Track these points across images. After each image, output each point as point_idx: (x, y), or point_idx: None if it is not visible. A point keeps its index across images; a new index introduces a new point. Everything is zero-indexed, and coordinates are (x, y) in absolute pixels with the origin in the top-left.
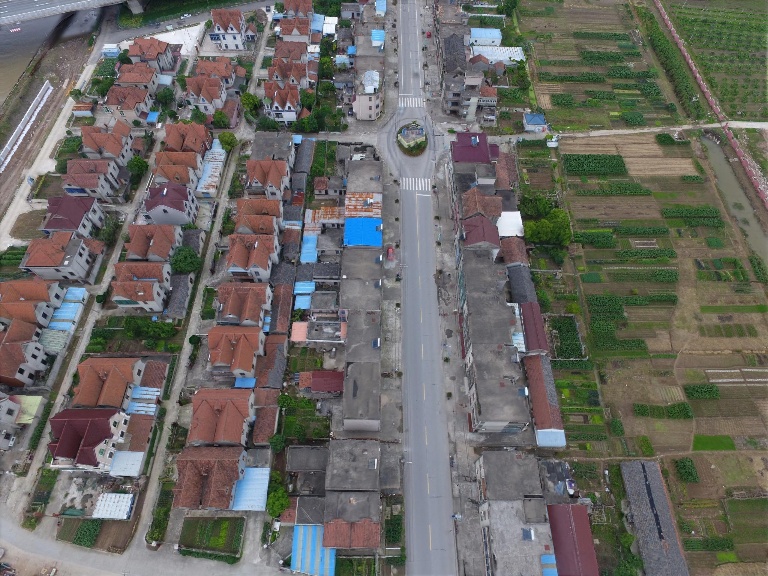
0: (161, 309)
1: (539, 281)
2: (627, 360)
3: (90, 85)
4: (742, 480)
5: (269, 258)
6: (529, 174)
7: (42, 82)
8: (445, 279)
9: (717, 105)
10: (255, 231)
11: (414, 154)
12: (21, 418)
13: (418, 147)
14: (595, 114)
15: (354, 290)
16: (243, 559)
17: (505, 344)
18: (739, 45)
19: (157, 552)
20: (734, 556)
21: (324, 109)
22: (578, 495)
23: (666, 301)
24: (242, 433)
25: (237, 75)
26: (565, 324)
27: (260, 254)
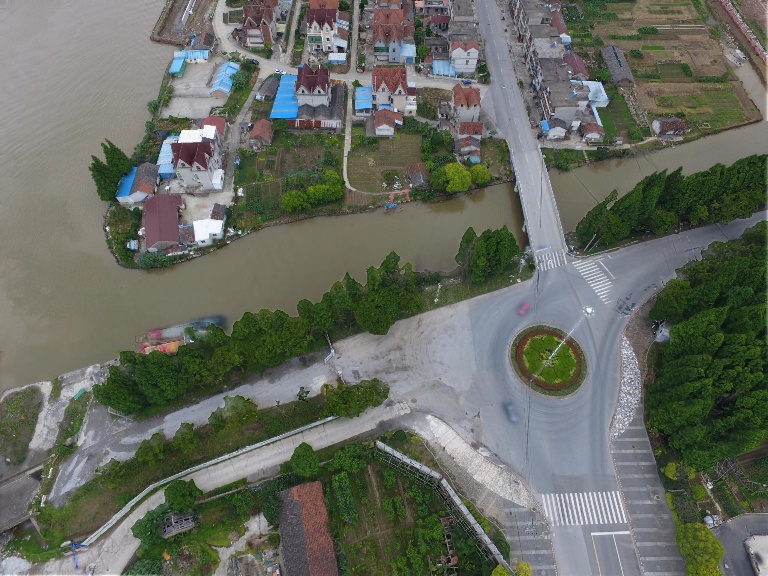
0: None
1: None
2: (606, 21)
3: None
4: (667, 59)
5: None
6: None
7: None
8: None
9: None
10: None
11: None
12: (278, 30)
13: None
14: None
15: None
16: (407, 75)
17: None
18: None
19: (363, 74)
20: None
21: None
22: None
23: (630, 1)
24: None
25: None
26: (570, 7)
27: None
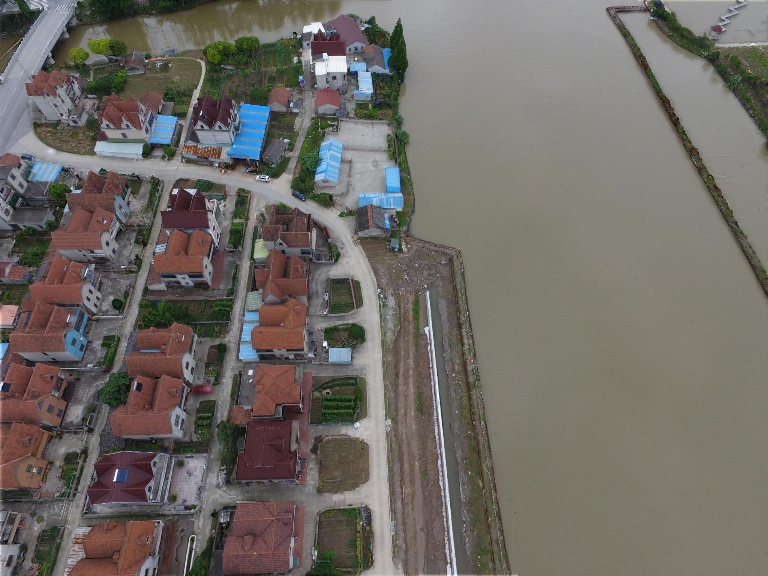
0: None
1: None
2: None
3: None
4: None
5: None
6: None
7: None
8: None
9: None
10: None
11: None
12: None
13: None
14: None
15: None
16: None
17: None
18: None
19: None
20: None
21: None
22: None
23: None
24: None
25: None
26: None
27: None
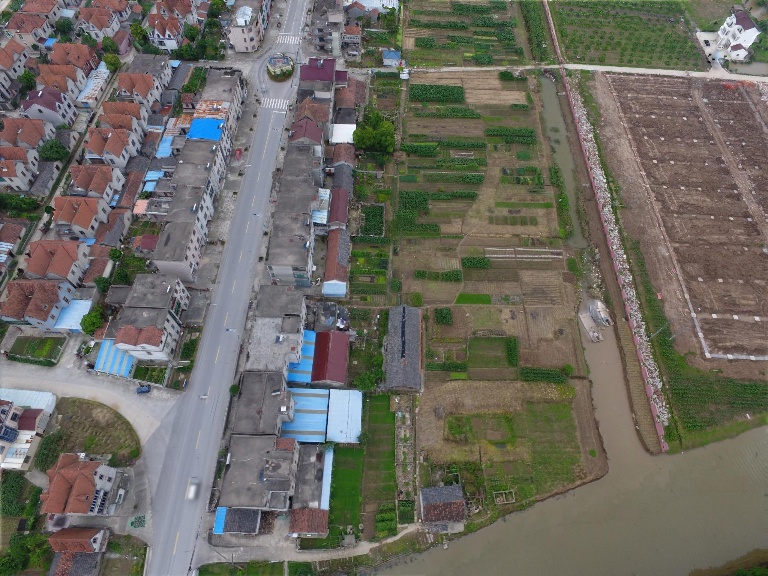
0: (27, 188)
1: (360, 178)
2: (420, 239)
3: (1, 16)
4: (489, 325)
5: (125, 150)
6: (378, 99)
7: None
8: None
9: (562, 51)
10: (116, 128)
11: (279, 80)
12: None
13: (284, 74)
14: (451, 54)
15: (186, 171)
16: (59, 364)
17: (303, 213)
18: (598, 4)
19: None
20: (465, 376)
21: (204, 40)
22: (347, 329)
23: (467, 197)
24: (72, 274)
25: (133, 11)
26: (373, 210)
27: (113, 143)
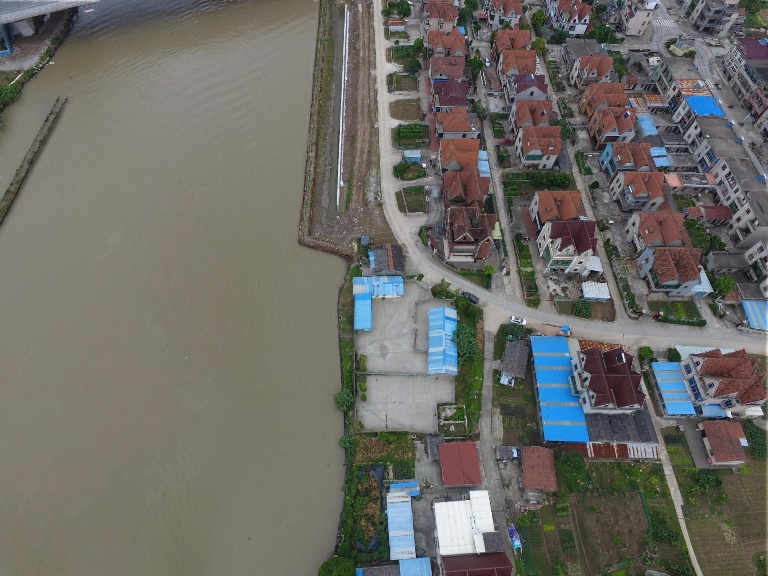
0: None
1: None
2: None
3: (388, 7)
4: None
5: None
6: None
7: (337, 7)
8: (759, 149)
9: None
10: None
11: None
12: (493, 235)
13: (689, 55)
14: None
15: (721, 145)
16: (707, 325)
17: None
18: None
19: (639, 321)
20: None
21: (604, 24)
22: None
23: None
24: None
25: None
26: None
27: None
